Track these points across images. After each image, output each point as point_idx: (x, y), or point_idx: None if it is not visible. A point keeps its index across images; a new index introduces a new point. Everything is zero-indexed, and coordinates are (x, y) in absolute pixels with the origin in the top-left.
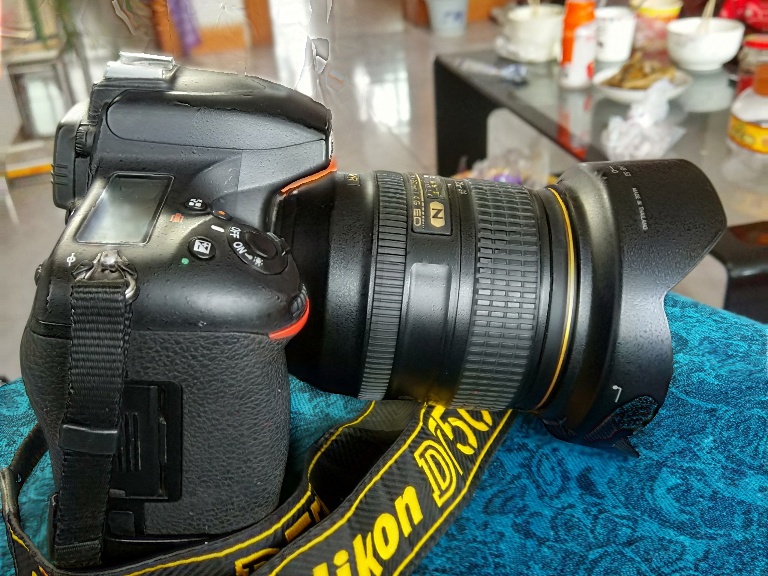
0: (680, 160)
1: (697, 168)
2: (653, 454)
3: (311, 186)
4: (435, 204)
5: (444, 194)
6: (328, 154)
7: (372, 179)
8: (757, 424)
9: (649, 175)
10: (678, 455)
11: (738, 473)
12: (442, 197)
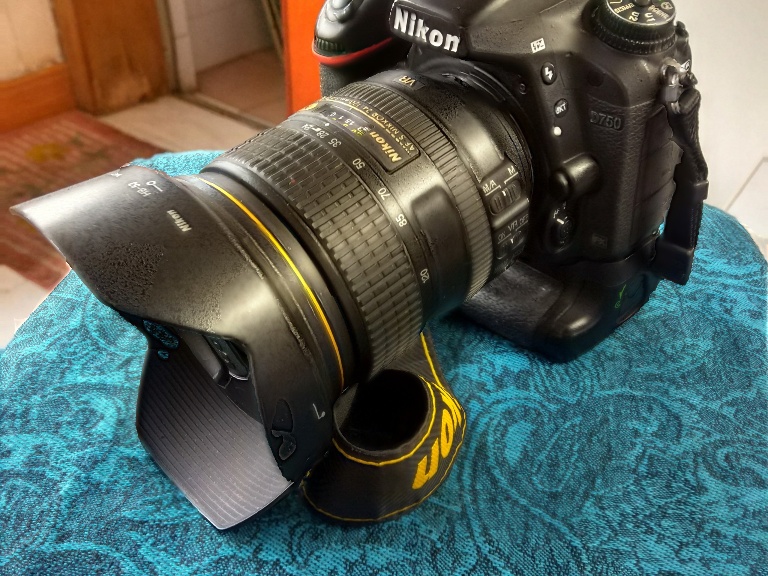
0: (70, 245)
1: (43, 226)
2: (125, 452)
3: (445, 80)
4: (314, 106)
5: (316, 113)
6: (394, 21)
7: (389, 85)
8: (3, 538)
9: (106, 193)
10: (97, 459)
11: (31, 462)
12: (315, 111)
